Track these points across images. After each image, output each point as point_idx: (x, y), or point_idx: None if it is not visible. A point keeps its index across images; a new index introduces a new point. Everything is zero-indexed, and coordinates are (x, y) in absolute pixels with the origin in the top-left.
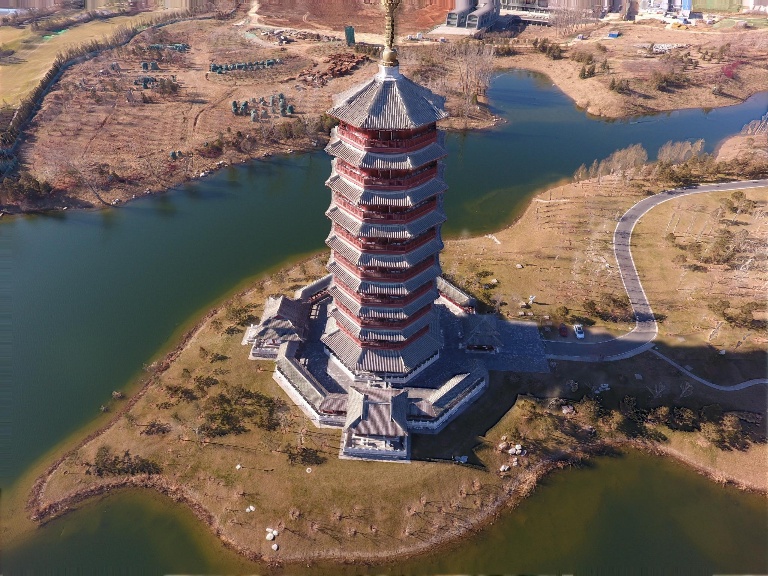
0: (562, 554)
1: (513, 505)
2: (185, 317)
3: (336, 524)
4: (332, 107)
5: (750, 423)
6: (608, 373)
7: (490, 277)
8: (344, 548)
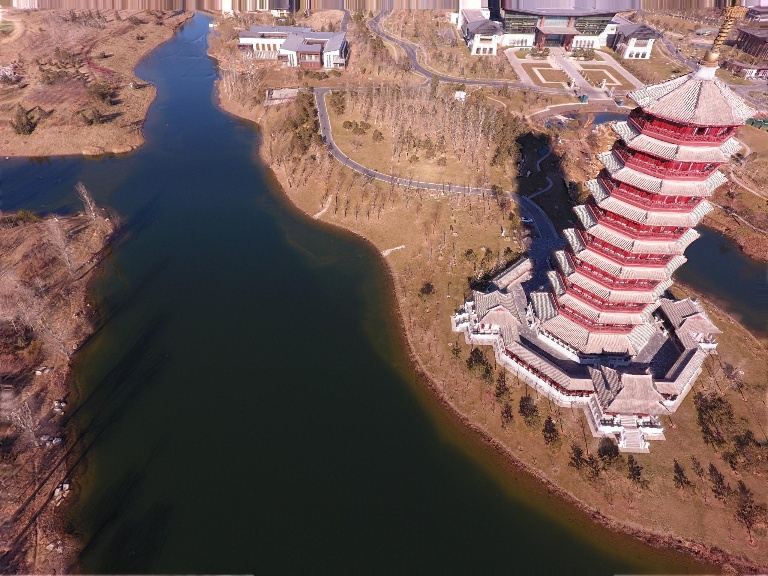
0: (685, 266)
1: (673, 278)
2: (615, 568)
3: (761, 358)
4: (727, 122)
5: (570, 183)
6: (559, 217)
7: (476, 251)
8: (767, 356)
